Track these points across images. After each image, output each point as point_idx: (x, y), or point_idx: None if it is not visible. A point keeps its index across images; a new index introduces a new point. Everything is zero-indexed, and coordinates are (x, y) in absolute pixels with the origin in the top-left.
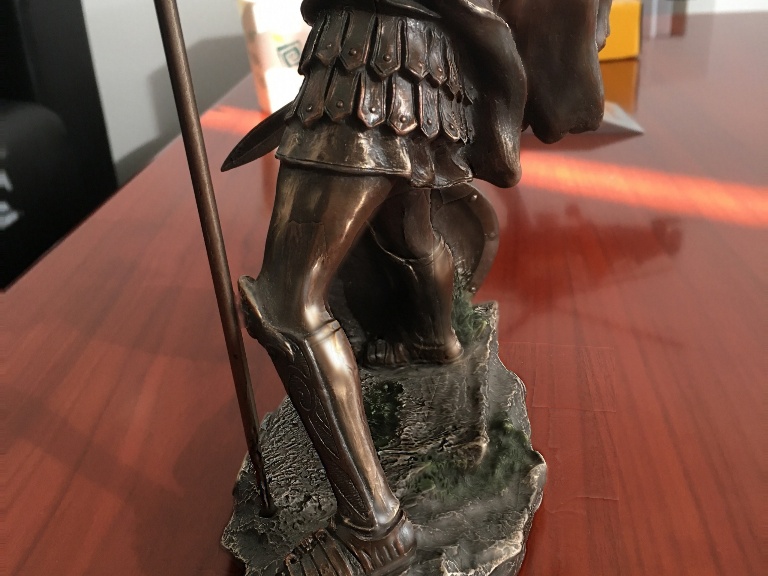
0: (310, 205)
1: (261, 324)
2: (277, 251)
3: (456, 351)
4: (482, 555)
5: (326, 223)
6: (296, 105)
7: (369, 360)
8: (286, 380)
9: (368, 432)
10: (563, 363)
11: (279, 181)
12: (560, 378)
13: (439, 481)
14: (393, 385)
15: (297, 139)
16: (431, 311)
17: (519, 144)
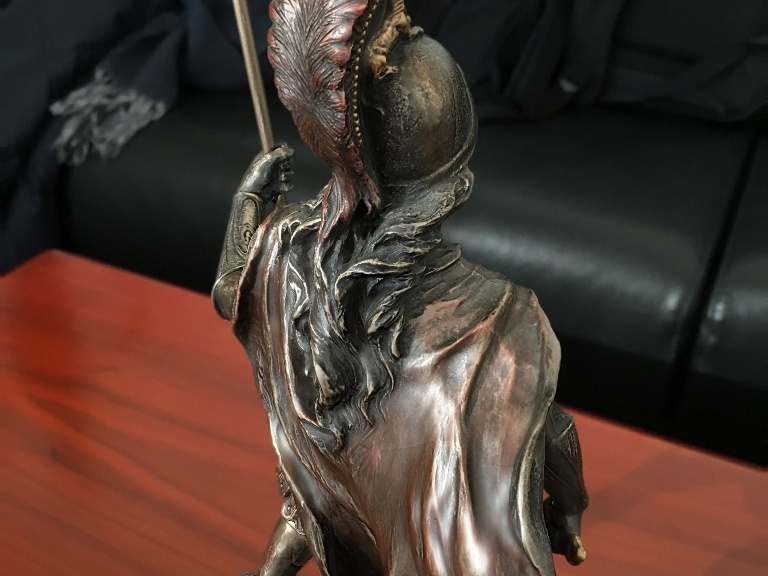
0: None
1: None
2: None
3: None
4: None
5: None
6: None
7: None
8: None
9: None
10: None
11: None
12: None
13: None
14: None
15: None
16: None
17: None
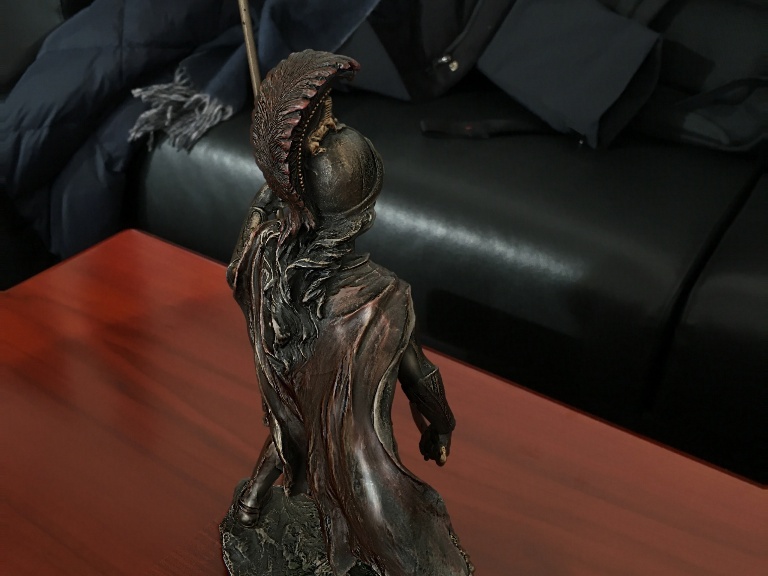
0: None
1: None
2: None
3: None
4: (238, 570)
5: None
6: None
7: None
8: None
9: (258, 475)
10: None
11: None
12: None
13: (294, 573)
14: None
15: None
16: None
17: (286, 480)
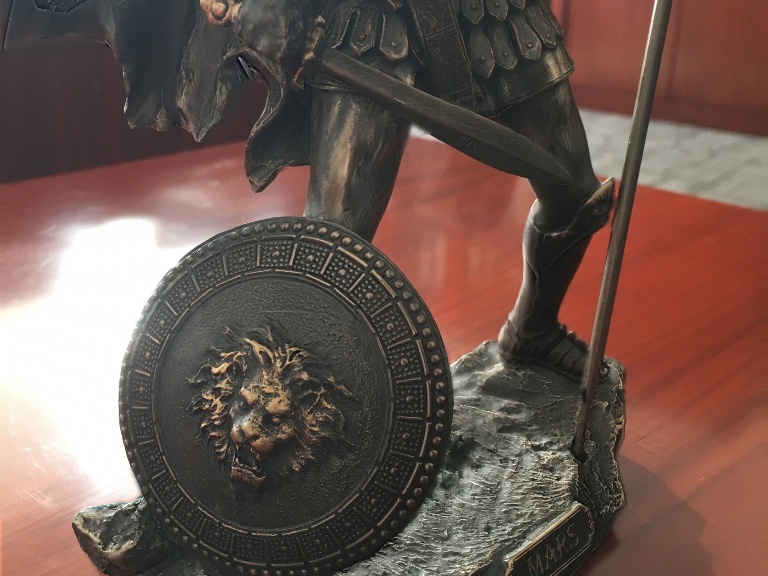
0: None
1: None
2: None
3: None
4: None
5: None
6: None
7: None
8: None
9: None
10: (53, 541)
11: None
12: None
13: None
14: None
15: None
16: None
17: None
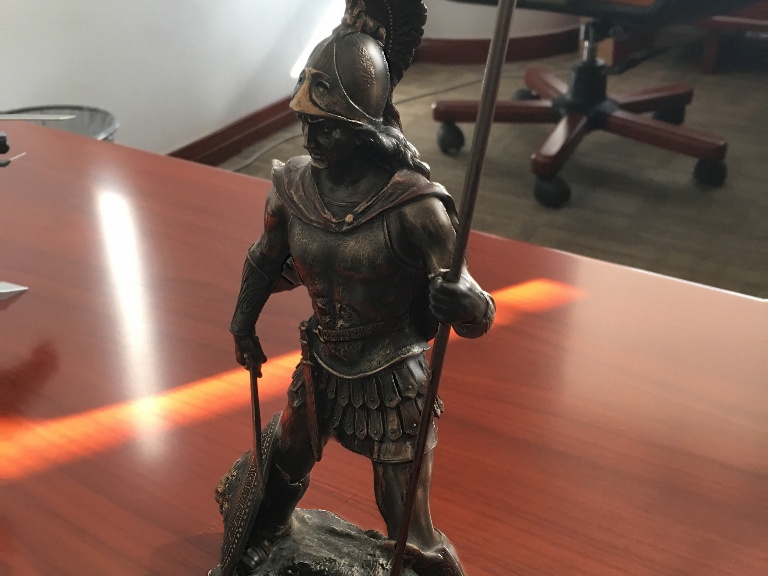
0: (422, 476)
1: (425, 556)
2: (414, 512)
3: (292, 520)
4: None
5: (429, 479)
6: (400, 428)
7: (252, 567)
8: (436, 575)
9: None
10: None
11: (396, 475)
12: (305, 495)
13: None
14: (295, 567)
15: (409, 446)
16: (295, 504)
17: None
